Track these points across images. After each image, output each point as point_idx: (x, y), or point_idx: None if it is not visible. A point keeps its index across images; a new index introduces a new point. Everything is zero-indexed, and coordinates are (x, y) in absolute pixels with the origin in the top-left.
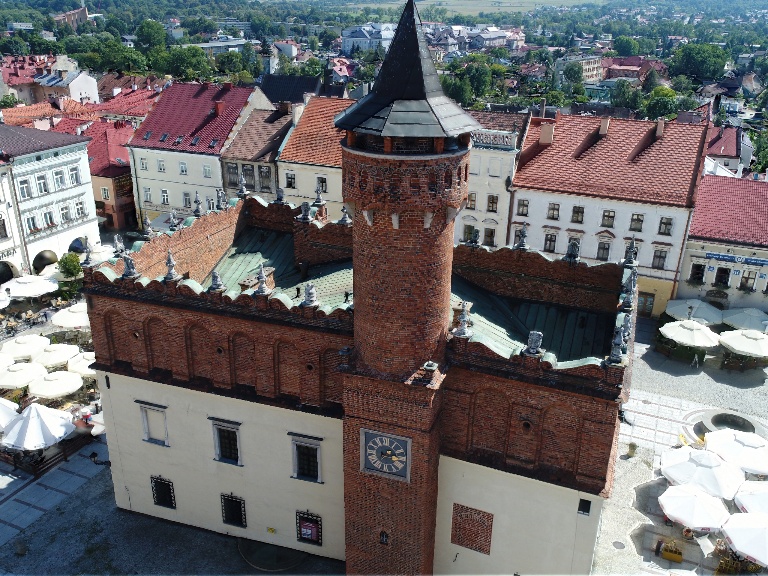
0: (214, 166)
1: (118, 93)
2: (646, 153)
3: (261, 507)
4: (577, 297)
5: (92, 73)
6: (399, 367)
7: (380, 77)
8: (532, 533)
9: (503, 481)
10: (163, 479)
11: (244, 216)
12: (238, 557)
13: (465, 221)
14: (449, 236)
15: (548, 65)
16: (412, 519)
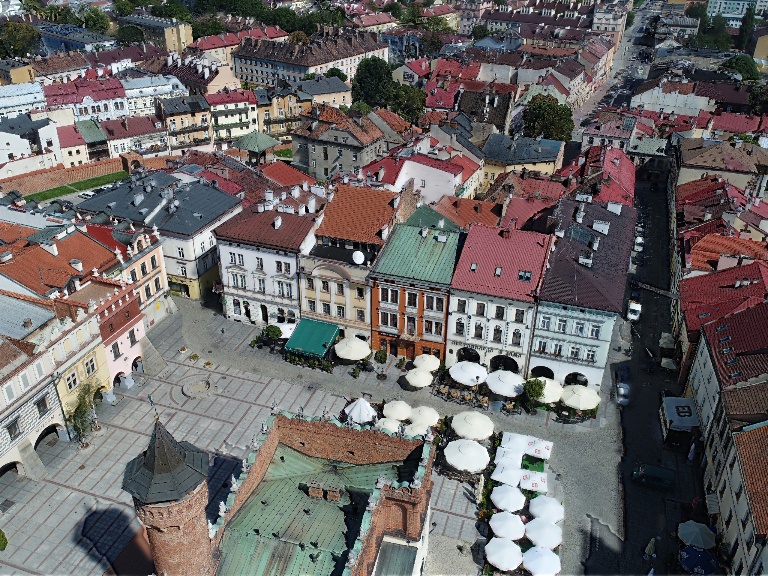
0: None
1: None
2: None
3: None
4: None
5: None
6: None
7: None
8: None
9: None
10: None
11: None
12: None
13: None
14: (156, 535)
15: None
16: None
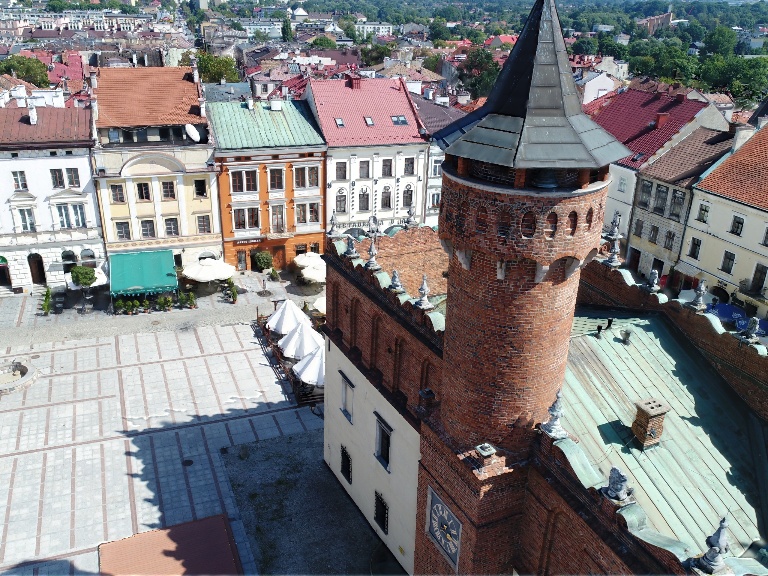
0: (630, 181)
1: (603, 95)
2: None
3: (398, 522)
4: None
5: (632, 76)
6: (460, 435)
7: (495, 84)
8: None
9: None
10: (347, 452)
11: None
12: (368, 557)
13: None
14: (542, 299)
15: None
16: None
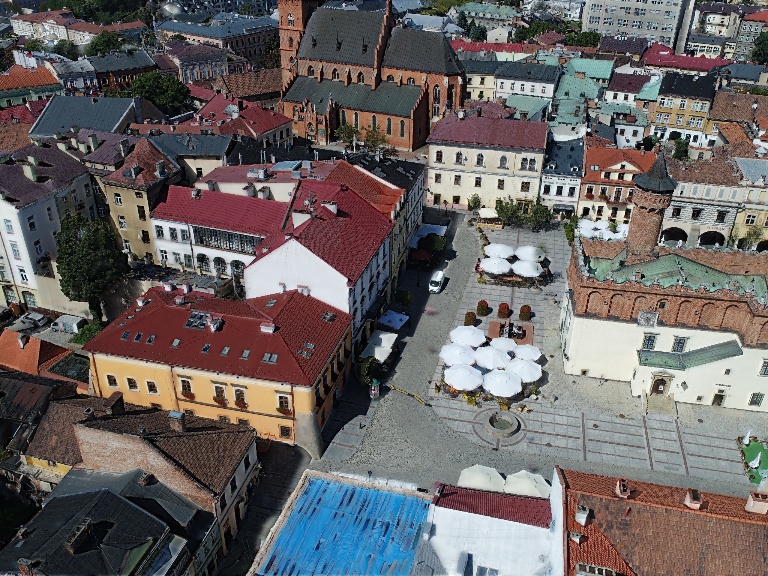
0: None
1: None
2: None
3: None
4: None
5: None
6: None
7: None
8: None
9: None
10: None
11: None
12: None
13: None
14: None
15: None
16: None
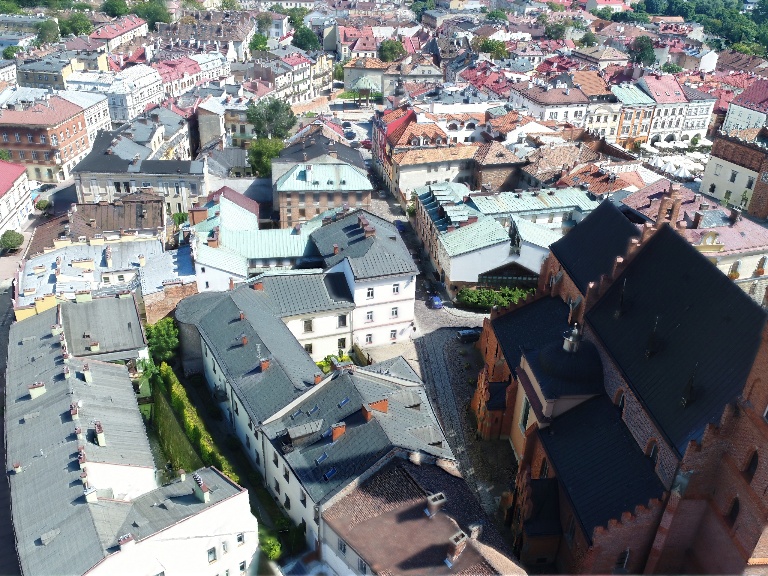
0: (763, 118)
1: (732, 73)
2: None
3: (735, 195)
4: None
5: (713, 41)
6: None
7: None
8: None
9: None
10: (714, 185)
11: (761, 132)
12: None
13: None
14: None
15: None
16: (767, 193)
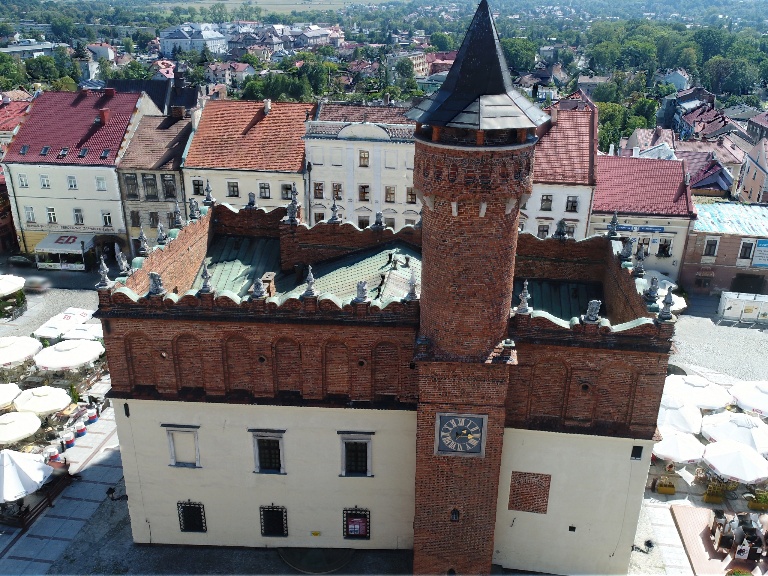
0: (109, 178)
1: None
2: (545, 139)
3: (305, 512)
4: (567, 271)
5: None
6: (478, 348)
7: (459, 74)
8: (588, 485)
9: (562, 442)
10: (193, 503)
11: (213, 224)
12: (285, 567)
13: (385, 214)
14: None
15: (380, 61)
16: (485, 492)
